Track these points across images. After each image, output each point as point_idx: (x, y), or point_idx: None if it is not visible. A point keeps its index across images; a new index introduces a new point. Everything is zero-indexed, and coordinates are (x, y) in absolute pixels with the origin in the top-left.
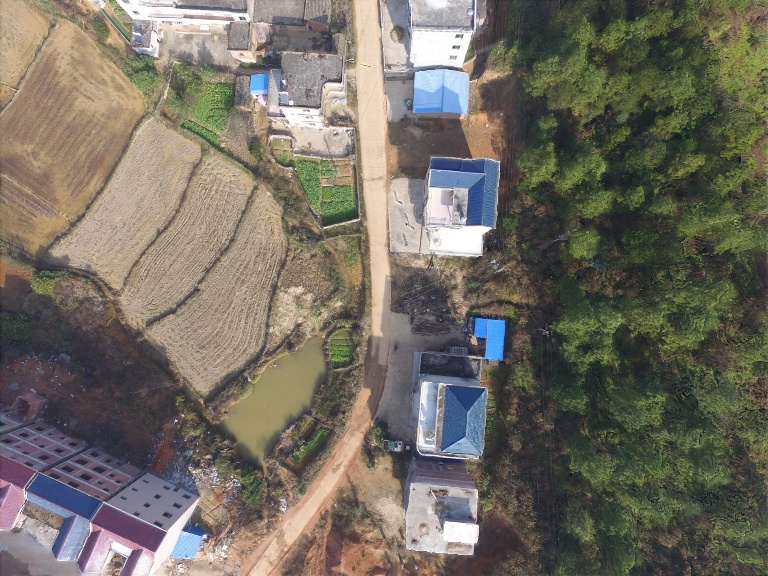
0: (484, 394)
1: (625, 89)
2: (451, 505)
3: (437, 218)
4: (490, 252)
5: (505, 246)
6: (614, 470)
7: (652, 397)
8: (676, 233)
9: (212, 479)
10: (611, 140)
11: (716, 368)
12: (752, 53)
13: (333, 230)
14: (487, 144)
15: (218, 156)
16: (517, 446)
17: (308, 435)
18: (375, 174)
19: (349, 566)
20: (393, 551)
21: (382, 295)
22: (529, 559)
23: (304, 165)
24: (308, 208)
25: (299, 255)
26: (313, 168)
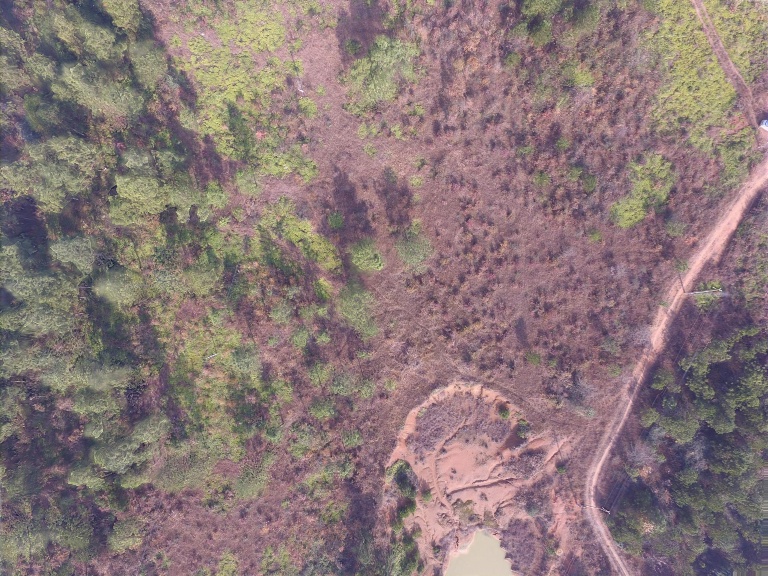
0: None
1: None
2: None
3: None
4: None
5: None
6: None
7: (5, 250)
8: None
9: None
10: None
11: (136, 240)
12: None
13: None
14: None
15: None
16: None
17: None
18: None
19: None
20: None
21: None
22: None
23: None
24: None
25: None
26: None
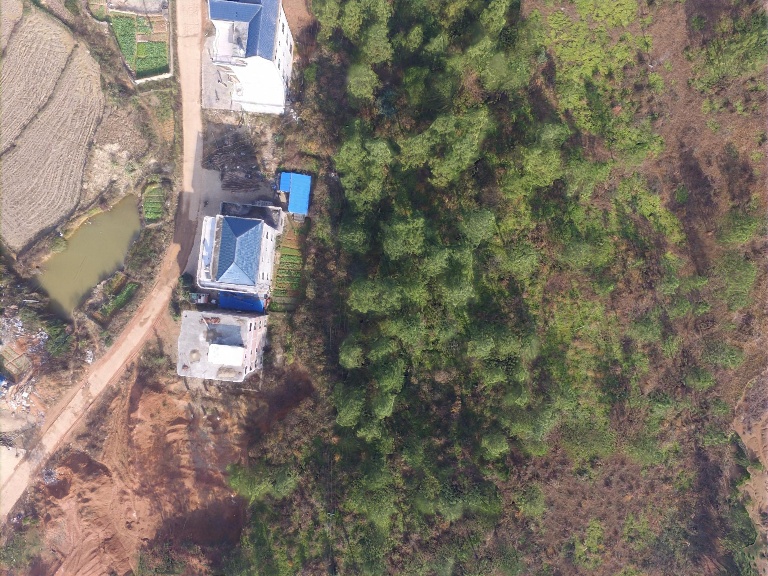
0: (261, 226)
1: None
2: (222, 332)
3: (223, 55)
4: (292, 104)
5: (306, 98)
6: (378, 297)
7: (411, 222)
8: (445, 68)
9: (16, 328)
10: None
11: (498, 214)
12: None
13: (146, 85)
14: (301, 4)
15: (39, 14)
16: (309, 291)
17: (119, 291)
18: (190, 31)
19: (146, 412)
20: (196, 403)
21: (194, 151)
22: (318, 403)
23: (119, 20)
24: (122, 63)
25: (115, 112)
26: (128, 23)
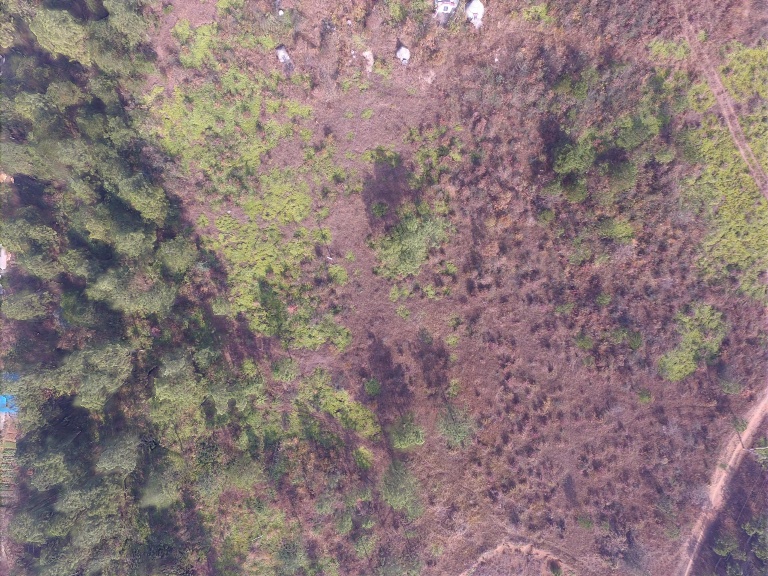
0: None
1: (41, 157)
2: None
3: None
4: None
5: None
6: None
7: (52, 458)
8: (88, 296)
9: None
10: (65, 202)
11: (176, 422)
12: (190, 113)
13: None
14: None
15: None
16: None
17: None
18: None
19: None
20: None
21: None
22: None
23: None
24: None
25: None
26: None
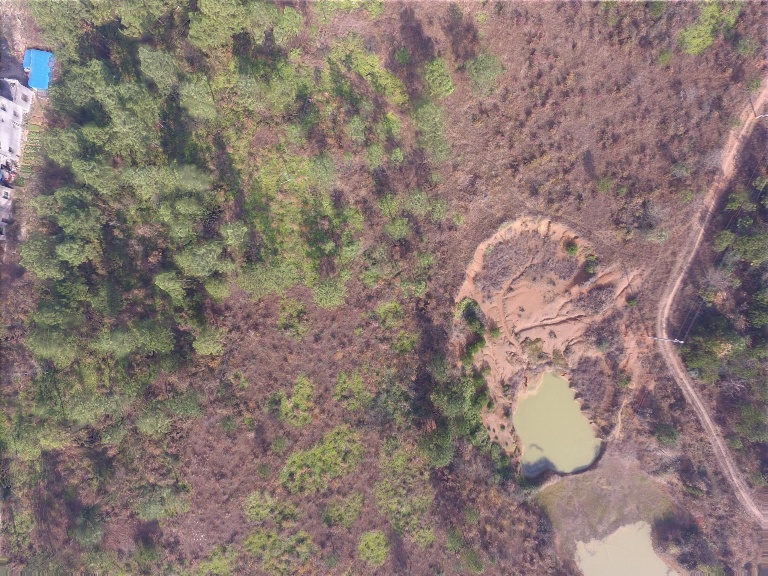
0: None
1: None
2: None
3: None
4: None
5: None
6: None
7: None
8: None
9: None
10: None
11: (209, 73)
12: None
13: None
14: None
15: None
16: None
17: None
18: None
19: None
20: None
21: None
22: None
23: None
24: None
25: None
26: None
